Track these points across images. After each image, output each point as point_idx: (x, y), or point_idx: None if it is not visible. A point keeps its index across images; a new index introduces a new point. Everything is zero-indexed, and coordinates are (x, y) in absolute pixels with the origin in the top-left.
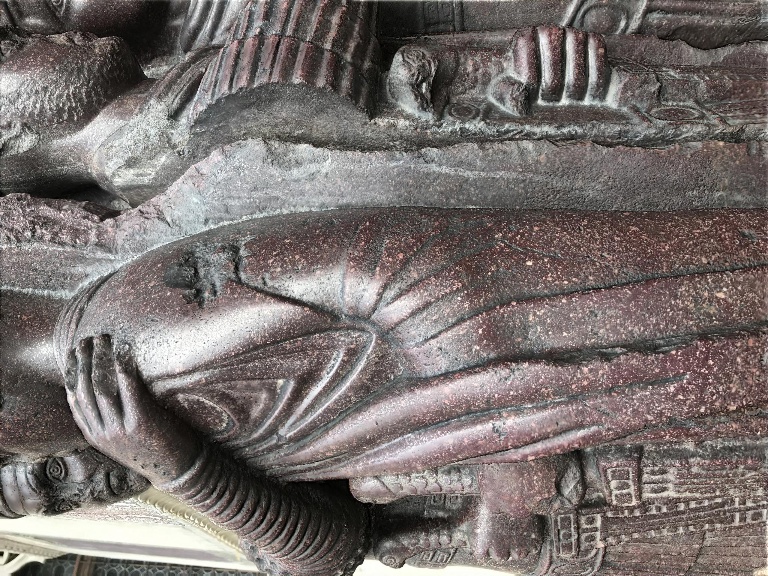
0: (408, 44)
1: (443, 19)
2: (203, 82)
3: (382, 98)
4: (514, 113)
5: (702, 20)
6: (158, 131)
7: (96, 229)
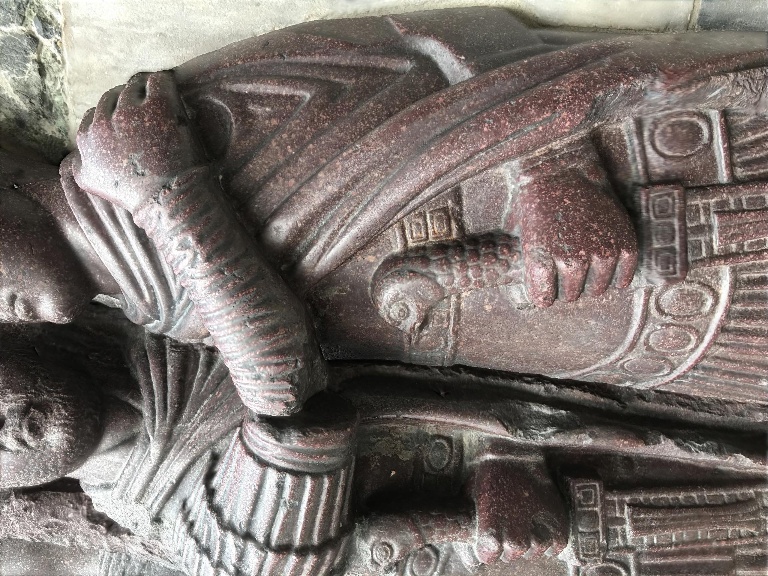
0: (379, 532)
1: (431, 361)
2: (184, 556)
3: (351, 549)
4: (468, 569)
5: (712, 396)
6: (145, 530)
7: (107, 543)
